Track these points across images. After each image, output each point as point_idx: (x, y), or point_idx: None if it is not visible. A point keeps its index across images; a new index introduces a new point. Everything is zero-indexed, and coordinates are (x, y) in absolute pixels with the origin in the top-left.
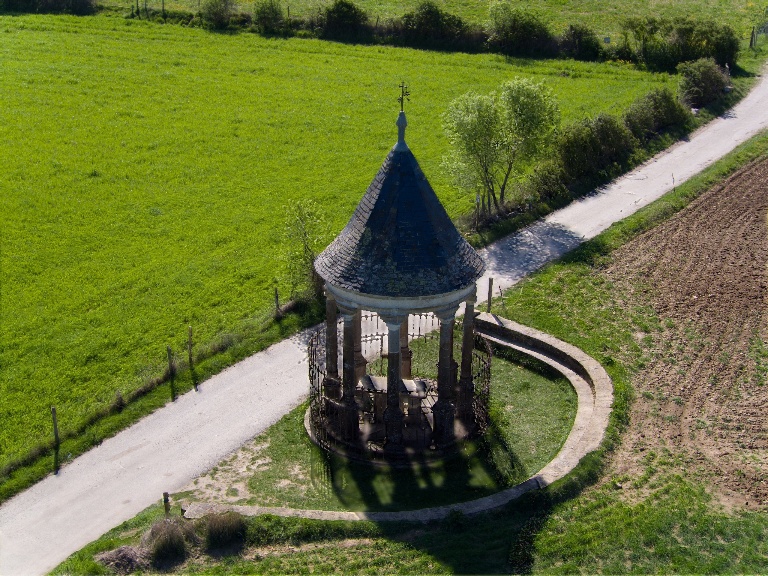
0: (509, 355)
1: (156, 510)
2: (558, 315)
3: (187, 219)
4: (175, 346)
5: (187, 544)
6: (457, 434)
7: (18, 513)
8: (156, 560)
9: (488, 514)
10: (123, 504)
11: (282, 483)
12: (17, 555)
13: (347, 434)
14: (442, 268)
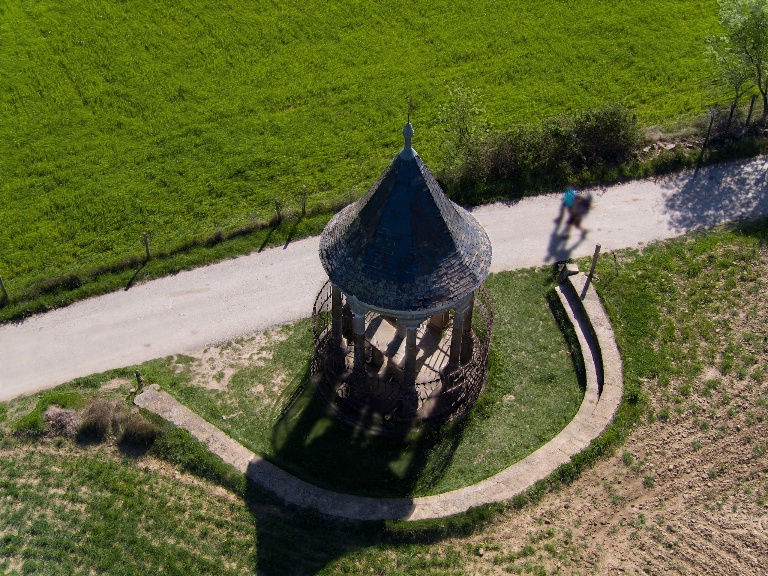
0: (568, 334)
1: (155, 366)
2: (659, 306)
3: (459, 14)
4: (314, 184)
5: (110, 430)
6: (422, 412)
7: (77, 317)
8: (81, 434)
9: (341, 523)
10: (143, 346)
11: (257, 388)
12: (47, 359)
13: (331, 368)
14: (406, 285)
